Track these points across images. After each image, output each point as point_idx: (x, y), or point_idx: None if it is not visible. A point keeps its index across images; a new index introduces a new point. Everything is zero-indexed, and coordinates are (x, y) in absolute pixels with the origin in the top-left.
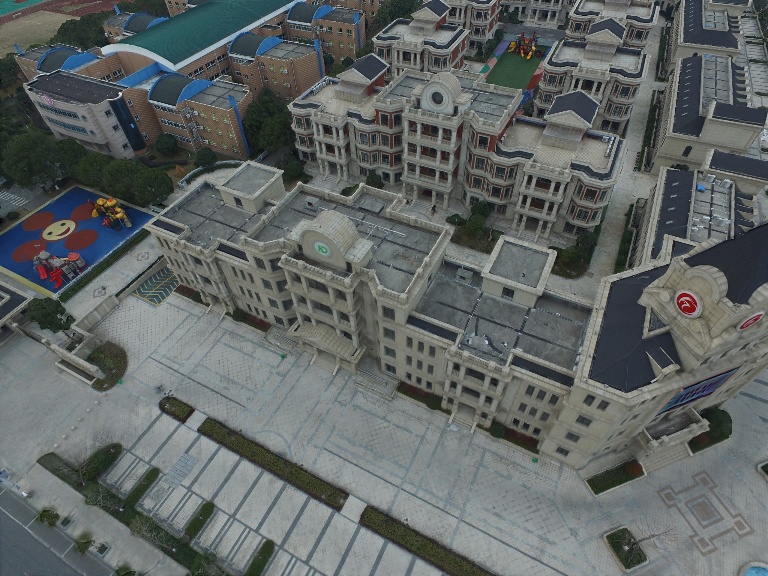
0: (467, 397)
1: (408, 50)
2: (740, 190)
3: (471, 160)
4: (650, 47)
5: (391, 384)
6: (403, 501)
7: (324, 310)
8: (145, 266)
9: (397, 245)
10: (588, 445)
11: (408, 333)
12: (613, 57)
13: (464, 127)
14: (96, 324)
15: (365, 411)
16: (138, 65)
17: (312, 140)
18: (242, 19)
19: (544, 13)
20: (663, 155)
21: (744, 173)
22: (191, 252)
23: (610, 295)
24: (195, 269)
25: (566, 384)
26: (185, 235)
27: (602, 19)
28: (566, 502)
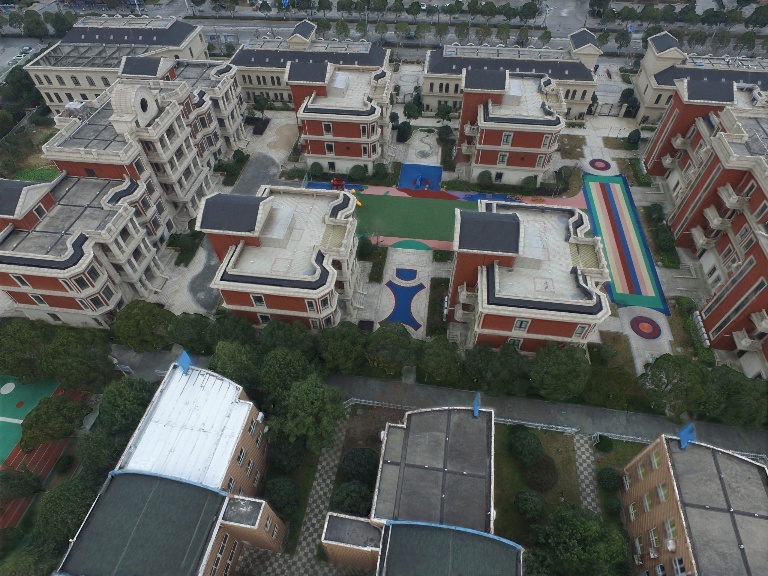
0: None
1: None
2: None
3: None
4: (294, 117)
5: None
6: None
7: None
8: None
9: None
10: None
11: None
12: None
13: None
14: None
15: None
16: None
17: None
18: None
19: None
20: (591, 101)
21: None
22: None
23: None
24: None
25: None
26: None
27: None
28: None
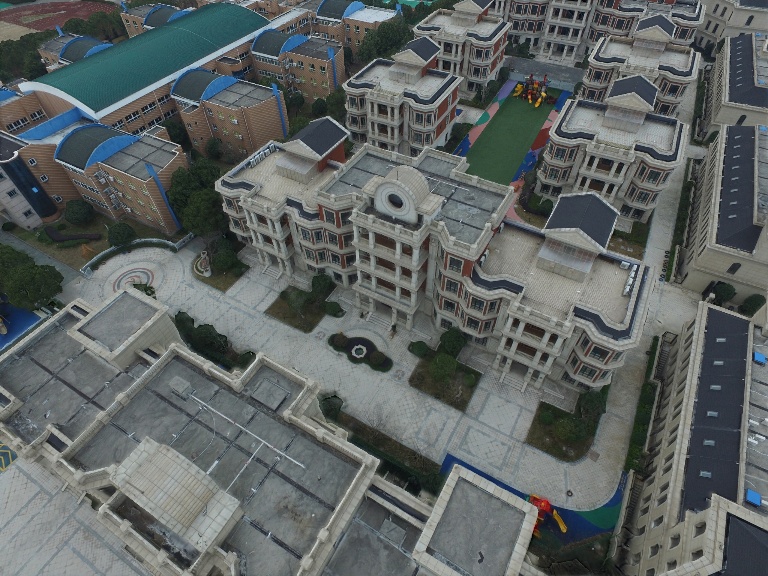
0: None
1: (384, 103)
2: None
3: (441, 279)
4: None
5: None
6: None
7: None
8: None
9: (289, 484)
10: None
11: None
12: (640, 127)
13: (431, 240)
14: None
15: None
16: (59, 108)
17: None
18: (194, 51)
19: (560, 46)
20: (701, 269)
21: None
22: (9, 443)
23: None
24: None
25: None
26: (10, 409)
27: (628, 69)
28: None
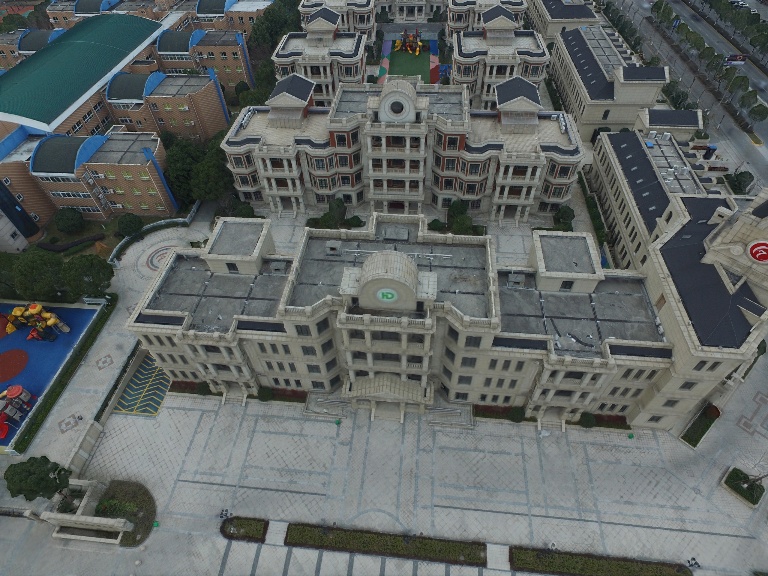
0: (557, 399)
1: (316, 64)
2: (676, 140)
3: (440, 163)
4: None
5: (464, 411)
6: (540, 527)
7: (387, 359)
8: (113, 373)
9: (448, 268)
10: (686, 406)
11: (495, 356)
12: (512, 41)
13: (429, 132)
14: (84, 465)
15: (454, 449)
16: None
17: (255, 178)
18: (107, 58)
19: (410, 9)
20: (586, 122)
21: (678, 124)
22: (206, 341)
23: (666, 261)
24: (207, 359)
25: (665, 357)
26: (187, 323)
27: (482, 7)
28: (676, 465)
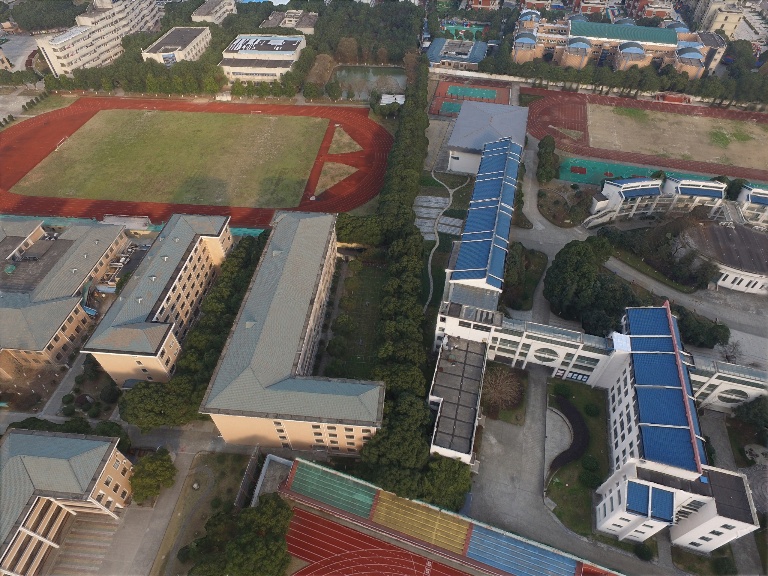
0: None
1: None
2: None
3: None
4: None
5: None
6: None
7: None
8: None
9: None
10: None
11: None
12: None
13: None
14: None
15: None
16: None
17: None
18: None
19: None
20: None
21: None
22: None
23: None
24: None
25: None
26: None
27: None
28: None
